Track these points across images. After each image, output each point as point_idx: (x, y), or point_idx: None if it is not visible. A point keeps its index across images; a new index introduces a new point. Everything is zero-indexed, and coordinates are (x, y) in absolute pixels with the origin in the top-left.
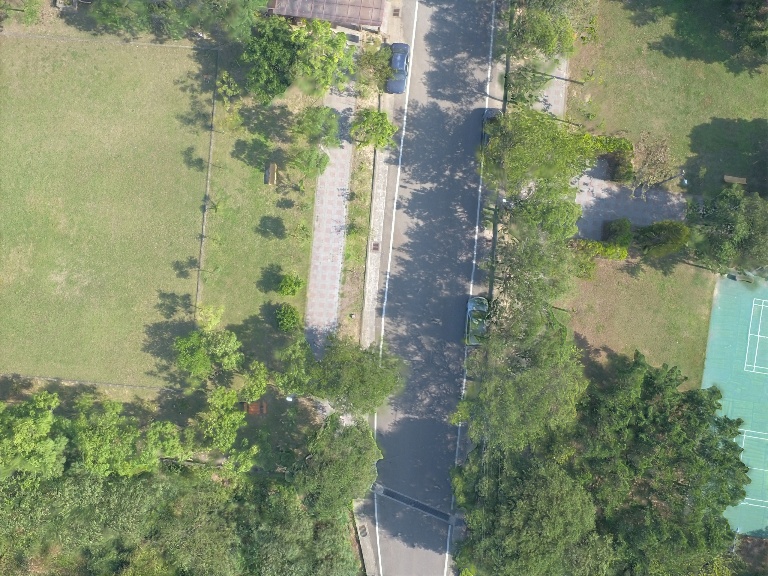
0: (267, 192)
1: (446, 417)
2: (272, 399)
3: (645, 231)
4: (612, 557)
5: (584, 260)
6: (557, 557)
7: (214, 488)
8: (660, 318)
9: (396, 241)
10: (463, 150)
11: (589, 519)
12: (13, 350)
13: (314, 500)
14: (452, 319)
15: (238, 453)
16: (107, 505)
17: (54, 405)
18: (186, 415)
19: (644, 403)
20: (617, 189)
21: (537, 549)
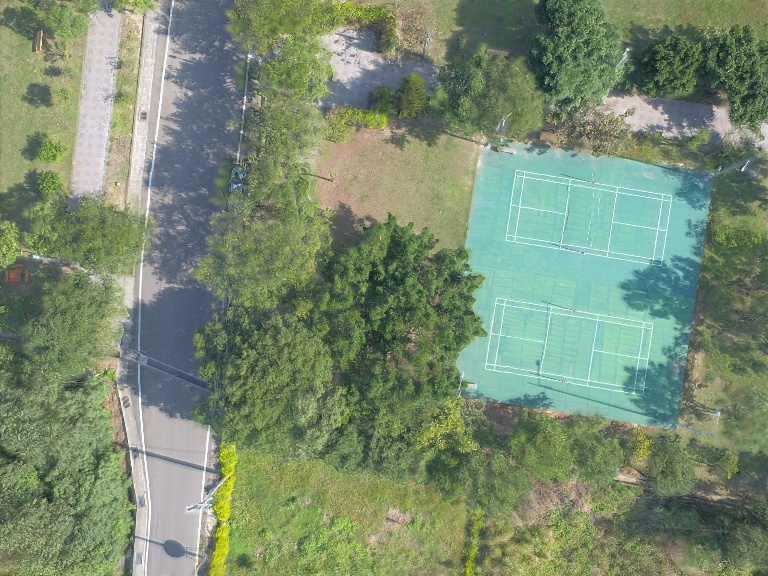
0: (35, 60)
1: (211, 287)
2: (36, 268)
3: (395, 92)
4: (345, 407)
5: (337, 122)
6: (285, 404)
7: None
8: (424, 188)
9: (164, 110)
10: (232, 21)
11: (324, 370)
12: None
13: (50, 353)
14: (218, 188)
15: None
16: None
17: None
18: None
19: (390, 261)
20: (382, 60)
21: (264, 395)
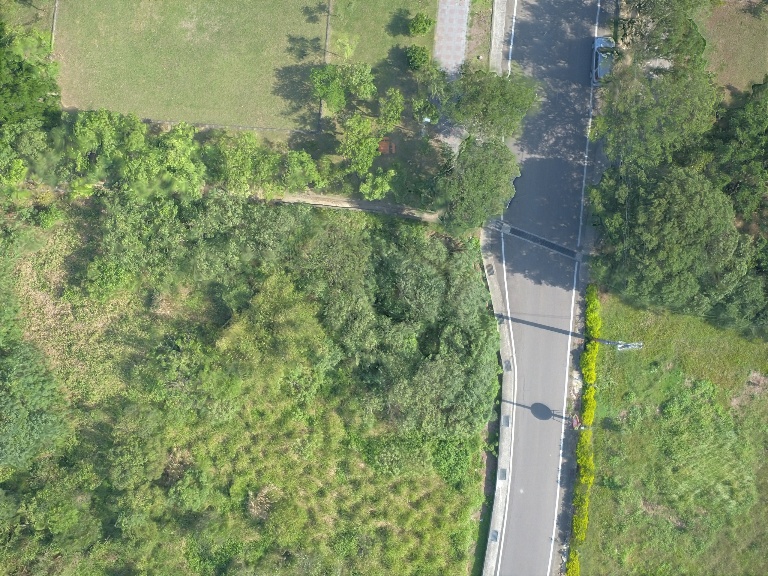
0: None
1: (572, 156)
2: (400, 141)
3: None
4: (754, 255)
5: None
6: (703, 249)
7: (343, 228)
8: None
9: None
10: None
11: (730, 220)
12: (144, 95)
13: (457, 207)
14: (578, 60)
15: (375, 177)
16: (247, 226)
17: (191, 135)
18: (315, 158)
19: None
20: None
21: (683, 240)
